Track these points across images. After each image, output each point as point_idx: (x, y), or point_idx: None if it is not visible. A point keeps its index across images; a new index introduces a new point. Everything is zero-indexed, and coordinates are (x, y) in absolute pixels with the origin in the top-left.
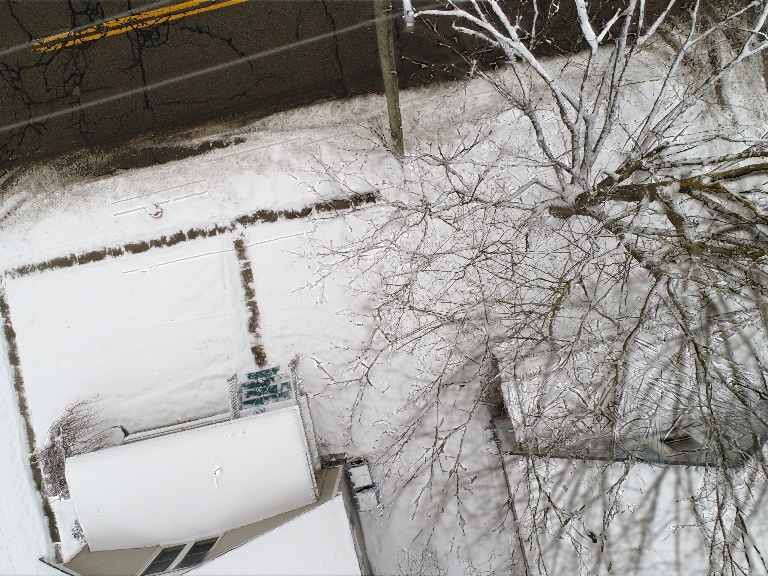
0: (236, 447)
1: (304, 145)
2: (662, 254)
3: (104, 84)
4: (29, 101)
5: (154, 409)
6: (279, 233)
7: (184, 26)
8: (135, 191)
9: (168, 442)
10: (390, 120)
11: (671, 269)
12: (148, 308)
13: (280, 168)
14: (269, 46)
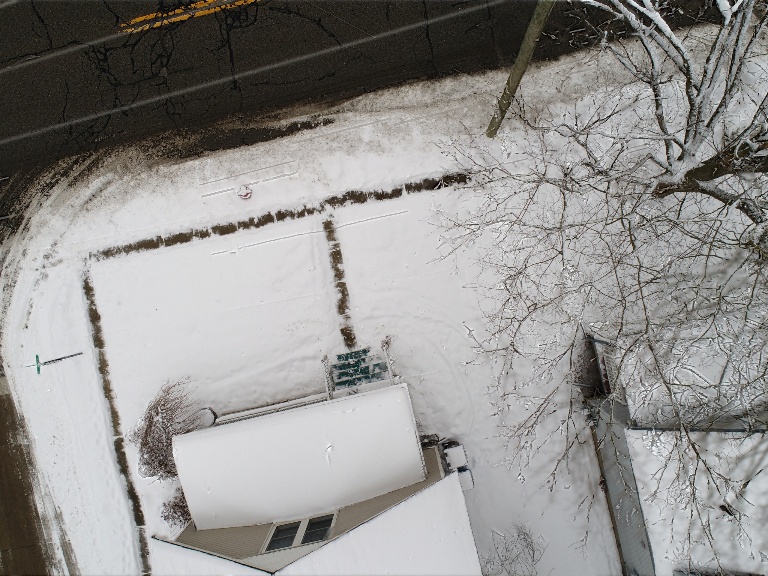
0: (347, 424)
1: (395, 125)
2: (760, 233)
3: (191, 65)
4: (115, 82)
5: (243, 391)
6: (369, 214)
7: (273, 7)
8: (223, 172)
9: (277, 420)
10: (505, 95)
11: None
12: (237, 289)
13: (371, 149)
14: (359, 26)
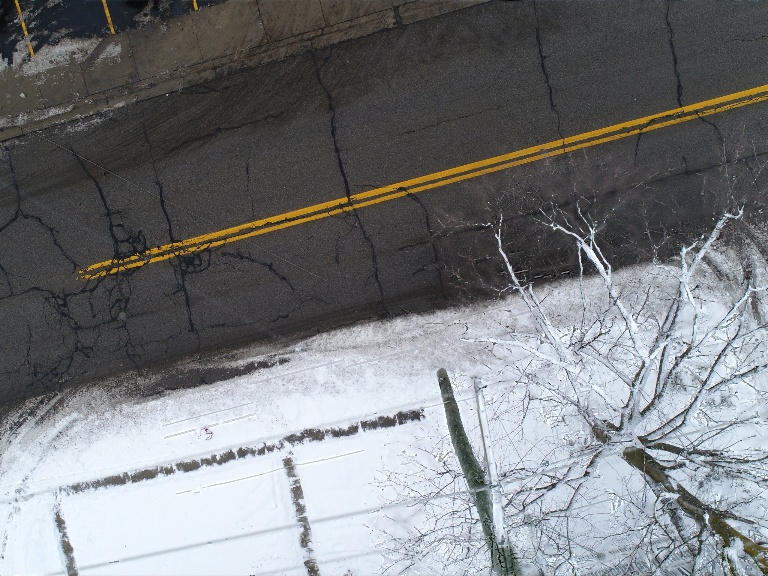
0: None
1: (348, 367)
2: (705, 473)
3: (149, 309)
4: (76, 326)
5: None
6: (327, 453)
7: (225, 252)
8: (184, 414)
9: None
10: None
11: (714, 486)
12: (202, 528)
13: (326, 390)
14: (310, 270)
